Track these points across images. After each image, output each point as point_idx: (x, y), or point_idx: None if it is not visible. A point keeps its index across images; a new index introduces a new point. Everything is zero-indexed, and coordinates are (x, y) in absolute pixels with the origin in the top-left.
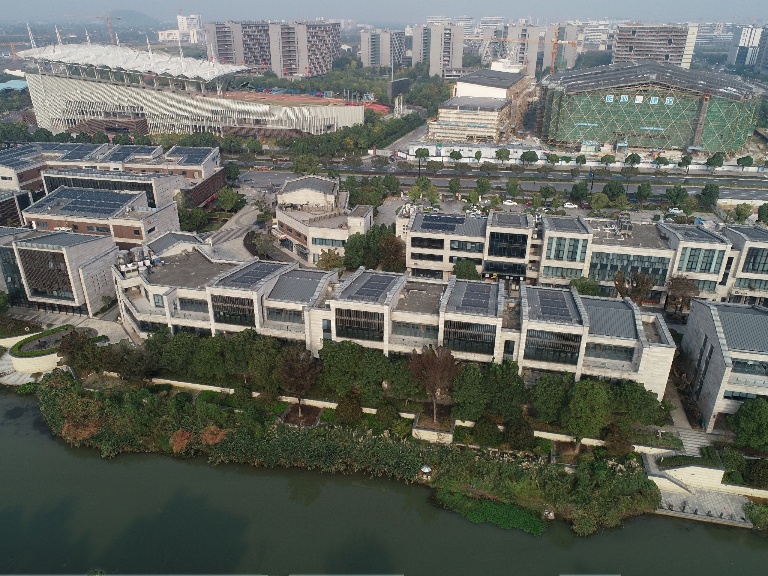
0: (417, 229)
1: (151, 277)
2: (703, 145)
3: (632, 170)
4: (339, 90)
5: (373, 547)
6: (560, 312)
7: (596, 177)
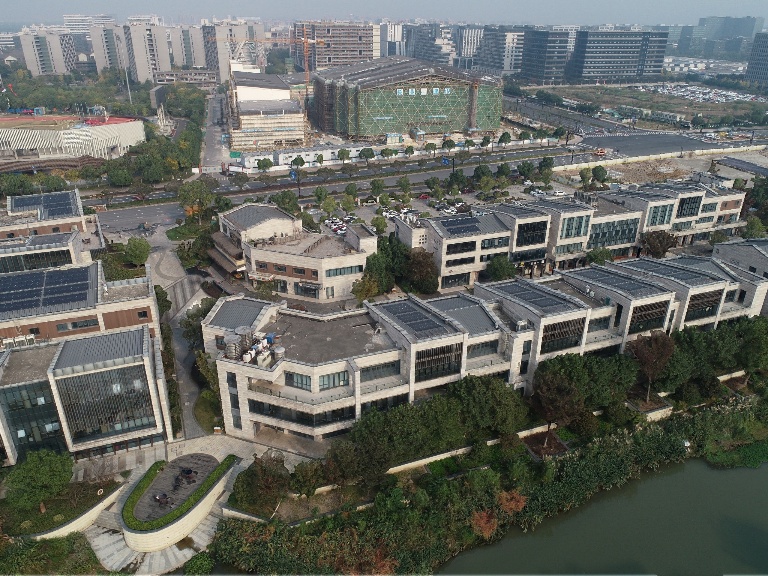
0: (449, 236)
1: (291, 358)
2: (477, 126)
3: (465, 154)
4: (54, 105)
5: (737, 524)
6: (688, 276)
7: (432, 164)
